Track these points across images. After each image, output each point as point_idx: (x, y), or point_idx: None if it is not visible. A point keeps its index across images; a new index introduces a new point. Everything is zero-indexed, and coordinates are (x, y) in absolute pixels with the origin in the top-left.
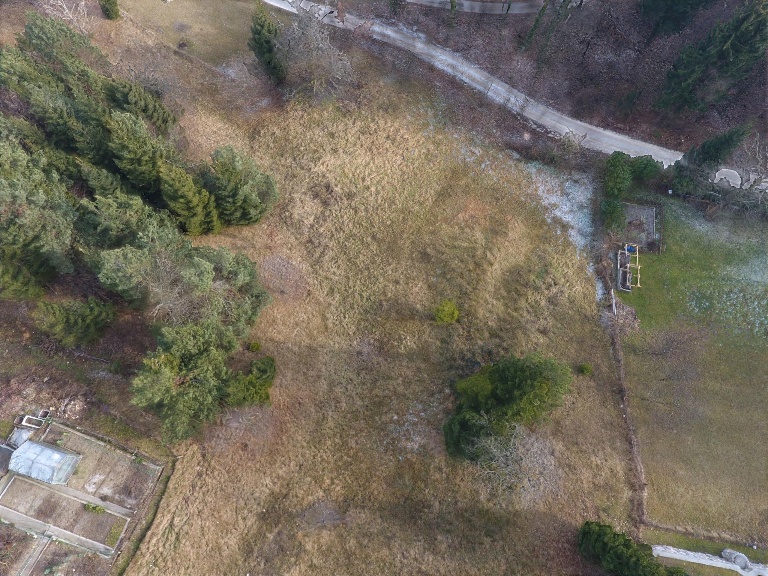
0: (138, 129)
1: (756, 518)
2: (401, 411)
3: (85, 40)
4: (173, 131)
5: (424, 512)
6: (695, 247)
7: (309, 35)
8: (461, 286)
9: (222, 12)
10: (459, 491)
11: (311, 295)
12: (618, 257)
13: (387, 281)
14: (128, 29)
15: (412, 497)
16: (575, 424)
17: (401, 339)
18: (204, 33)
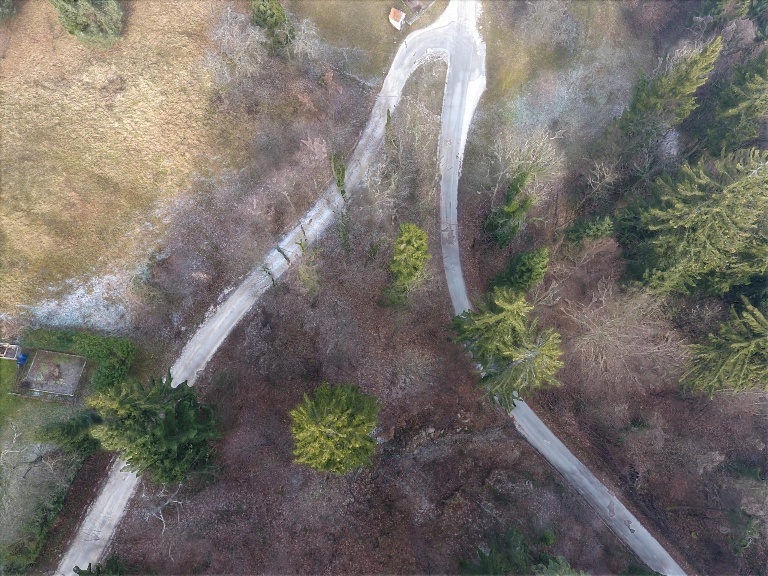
0: None
1: None
2: None
3: None
4: None
5: None
6: None
7: None
8: None
9: (362, 7)
10: None
11: None
12: None
13: (1, 130)
14: None
15: None
16: None
17: None
18: None
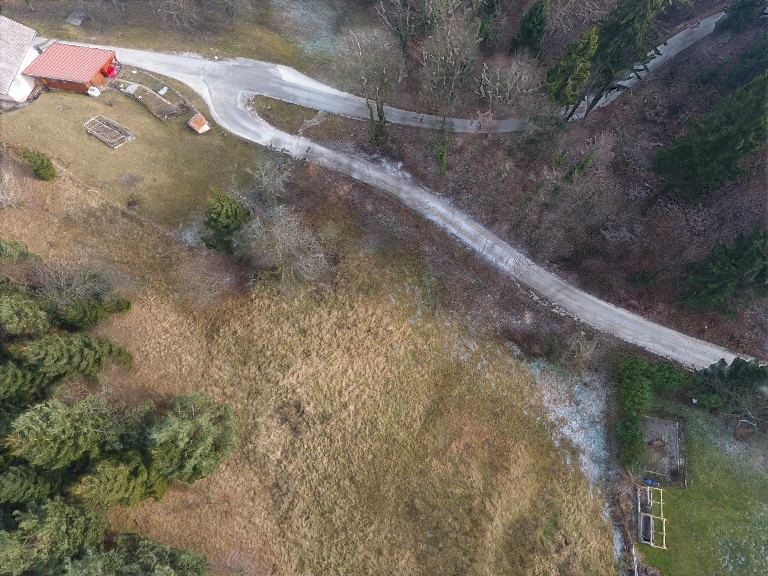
0: (50, 430)
1: None
2: None
3: (3, 248)
4: (105, 382)
5: None
6: (726, 477)
7: (273, 235)
8: (456, 560)
9: (179, 154)
10: None
11: (277, 572)
12: (638, 496)
13: (368, 550)
14: (67, 190)
15: None
16: None
17: None
18: (158, 185)
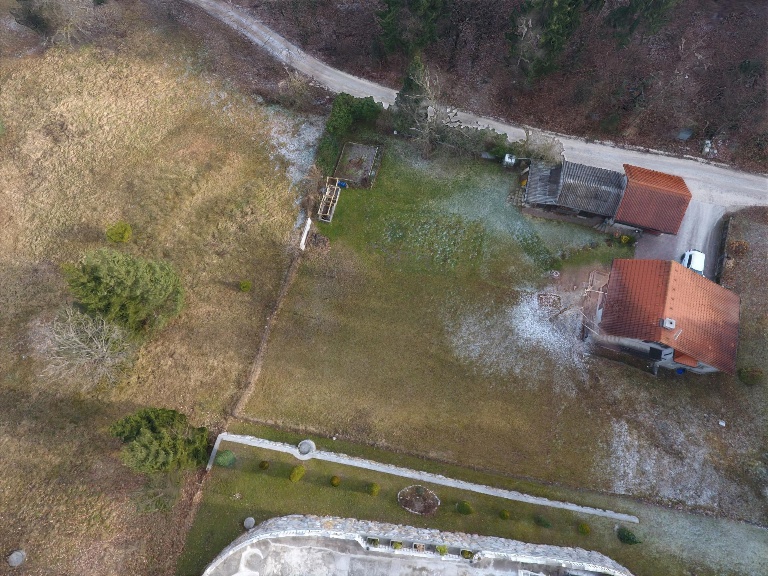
0: None
1: (351, 415)
2: (46, 318)
3: None
4: None
5: (21, 401)
6: (406, 183)
7: None
8: (152, 212)
9: None
10: (64, 385)
11: (12, 220)
12: None
13: (87, 208)
14: None
15: (16, 389)
16: (209, 332)
17: (78, 258)
18: None
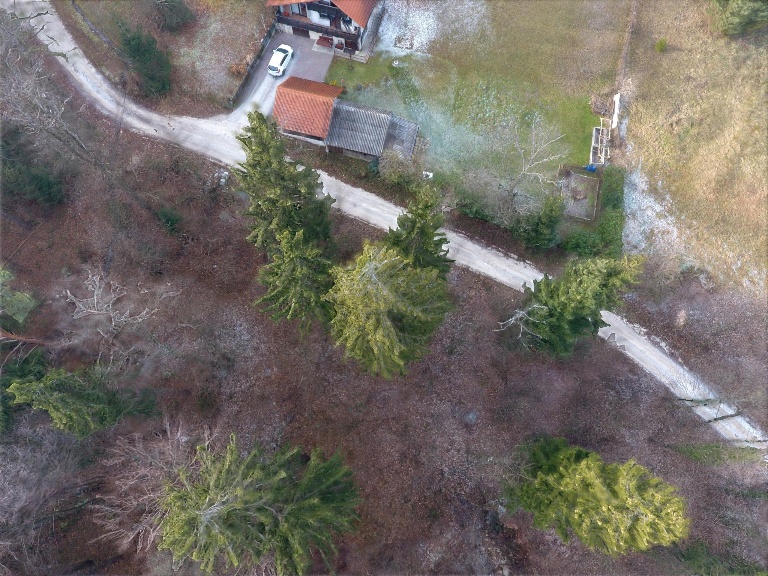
0: None
1: None
2: None
3: None
4: None
5: None
6: None
7: None
8: (767, 111)
9: None
10: None
11: None
12: None
13: None
14: None
15: None
16: (681, 0)
17: None
18: None
